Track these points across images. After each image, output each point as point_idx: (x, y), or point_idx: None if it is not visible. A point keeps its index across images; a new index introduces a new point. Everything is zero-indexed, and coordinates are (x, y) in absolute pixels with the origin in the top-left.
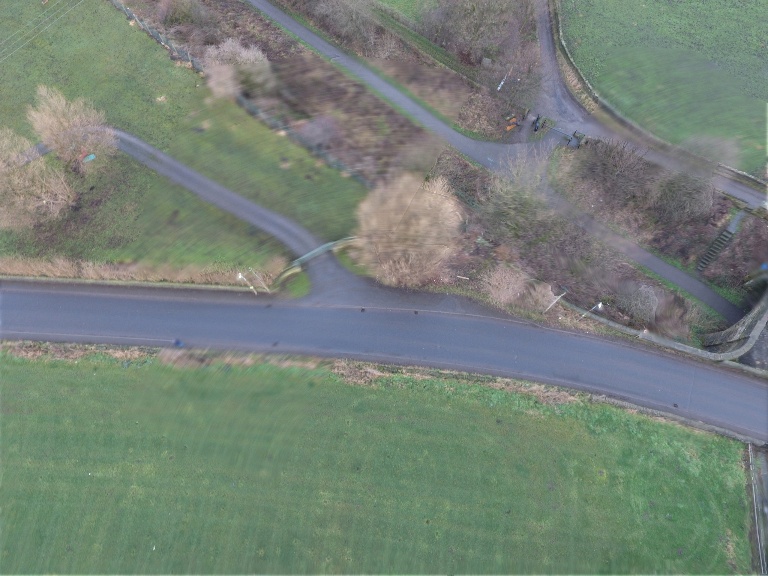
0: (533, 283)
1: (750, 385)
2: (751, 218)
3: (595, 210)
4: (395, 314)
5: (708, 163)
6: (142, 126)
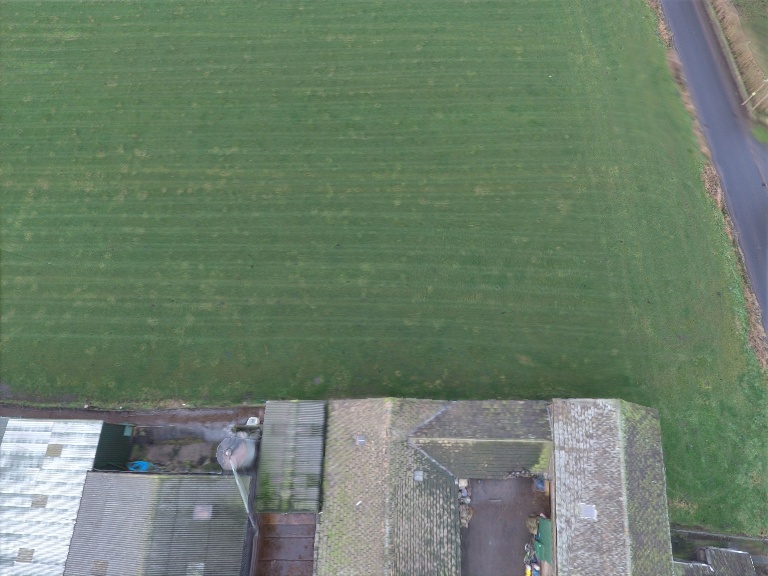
0: None
1: None
2: None
3: None
4: None
5: None
6: None
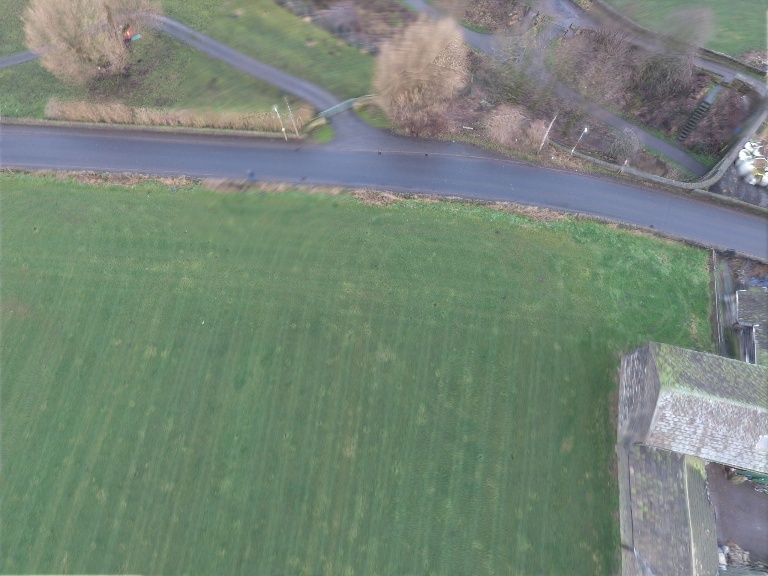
0: (529, 122)
1: (717, 211)
2: (727, 90)
3: (588, 91)
4: (408, 156)
5: (690, 47)
6: (182, 12)
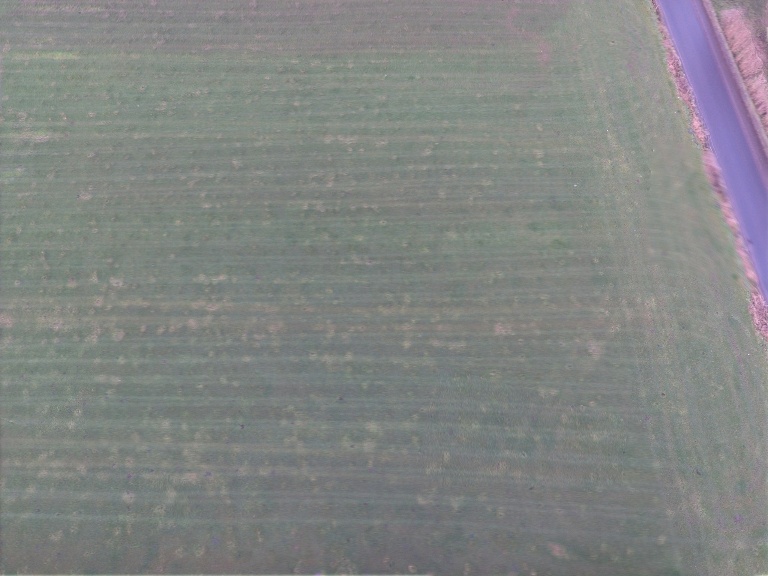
0: None
1: None
2: None
3: None
4: None
5: None
6: None
